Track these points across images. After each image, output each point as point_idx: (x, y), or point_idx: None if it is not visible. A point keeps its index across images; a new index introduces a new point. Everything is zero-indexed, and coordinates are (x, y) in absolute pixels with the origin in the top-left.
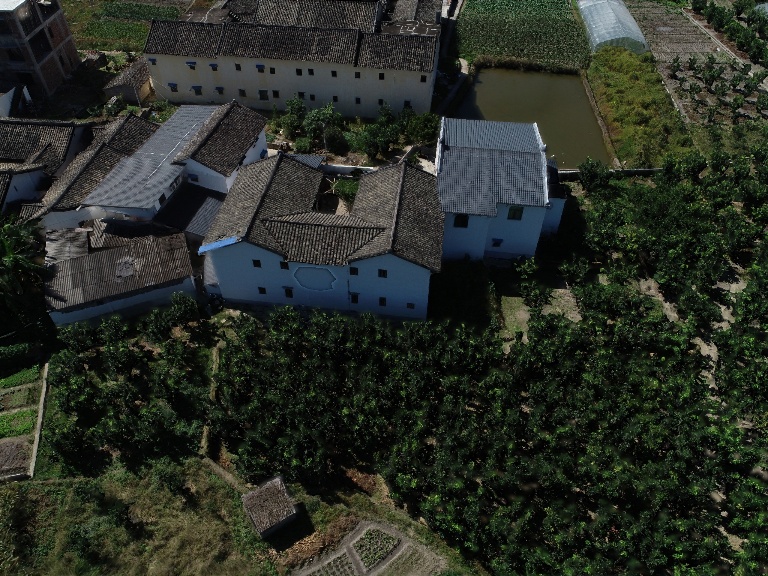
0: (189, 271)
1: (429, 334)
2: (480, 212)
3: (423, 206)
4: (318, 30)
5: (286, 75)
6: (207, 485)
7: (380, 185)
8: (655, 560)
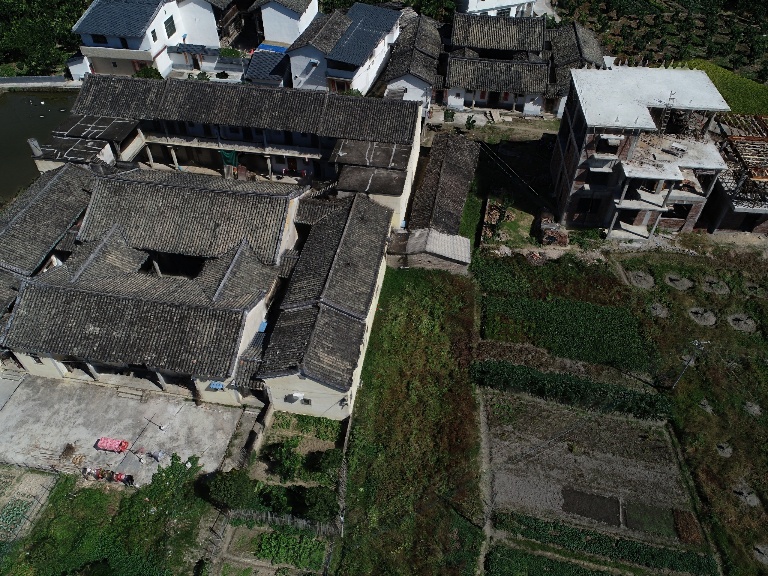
0: None
1: None
2: None
3: None
4: None
5: None
6: None
7: None
8: None
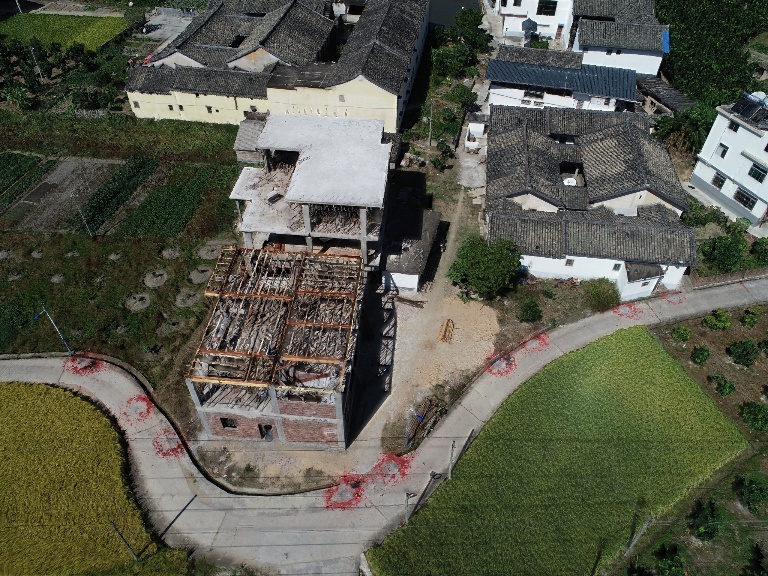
0: (658, 78)
1: None
2: None
3: None
4: (391, 8)
5: (415, 48)
6: None
7: (591, 4)
8: (731, 6)
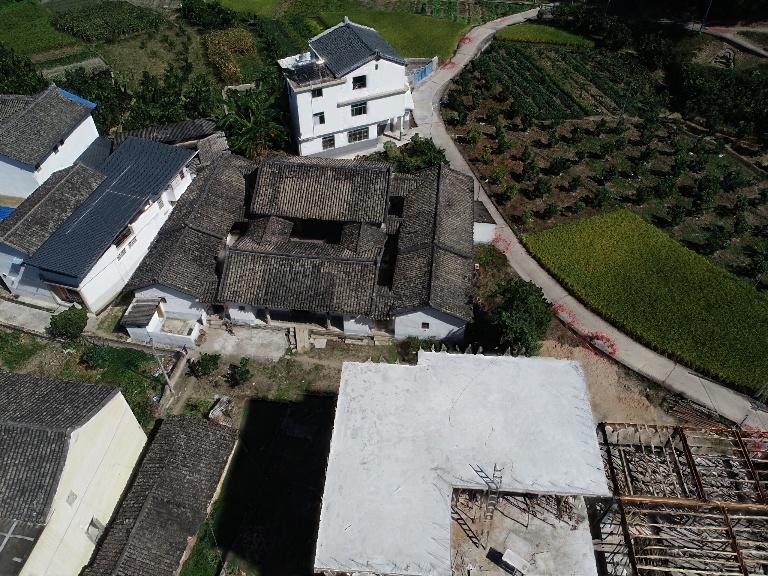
0: None
1: None
2: None
3: None
4: None
5: None
6: (134, 86)
7: None
8: None
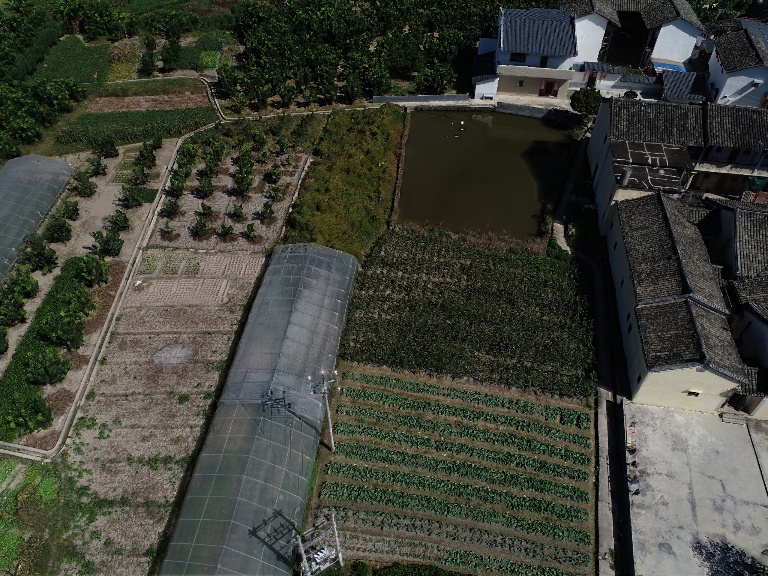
0: None
1: (555, 4)
2: (540, 8)
3: (575, 4)
4: None
5: None
6: None
7: (605, 11)
8: None
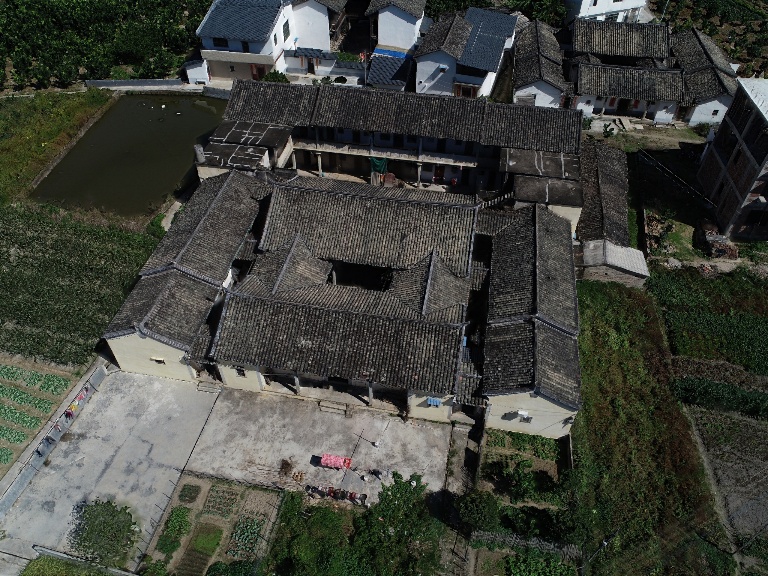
0: None
1: None
2: None
3: None
4: None
5: None
6: None
7: None
8: None
